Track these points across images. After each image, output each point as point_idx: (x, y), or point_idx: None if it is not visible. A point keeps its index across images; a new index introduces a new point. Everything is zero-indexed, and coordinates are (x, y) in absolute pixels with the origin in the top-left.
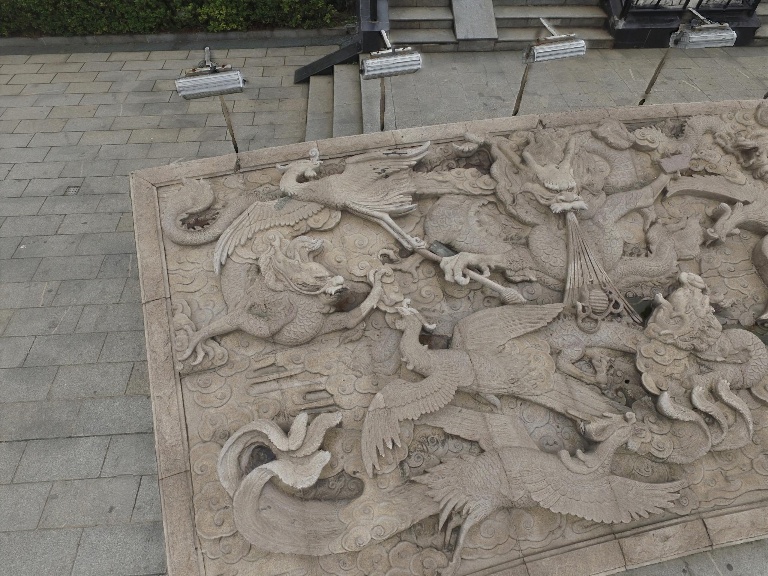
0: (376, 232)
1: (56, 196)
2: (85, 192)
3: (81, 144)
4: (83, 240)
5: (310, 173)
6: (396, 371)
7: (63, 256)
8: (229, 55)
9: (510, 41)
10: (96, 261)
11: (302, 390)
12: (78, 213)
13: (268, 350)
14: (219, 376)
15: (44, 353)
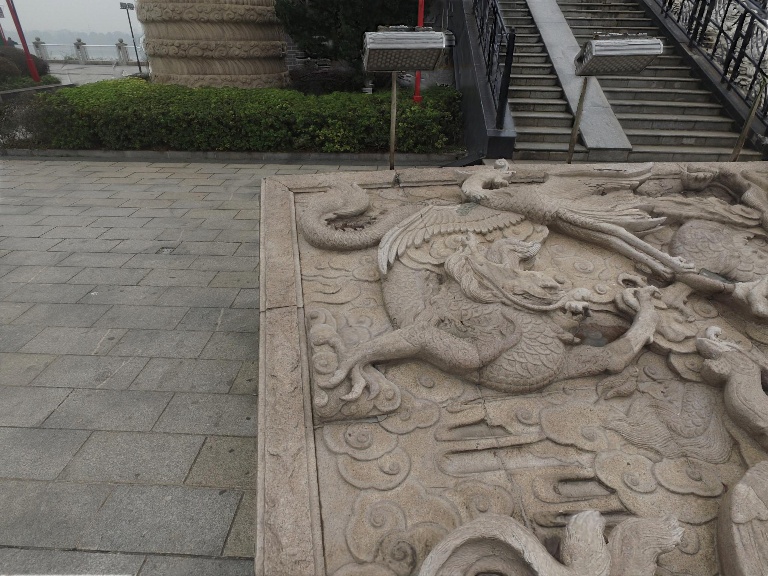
0: (601, 257)
1: (147, 254)
2: (180, 252)
3: (185, 217)
4: (167, 292)
5: (502, 179)
6: (728, 456)
7: (139, 305)
8: (340, 168)
9: (645, 152)
10: (178, 312)
11: (550, 473)
12: (167, 268)
13: (469, 396)
14: (385, 431)
15: (77, 411)
